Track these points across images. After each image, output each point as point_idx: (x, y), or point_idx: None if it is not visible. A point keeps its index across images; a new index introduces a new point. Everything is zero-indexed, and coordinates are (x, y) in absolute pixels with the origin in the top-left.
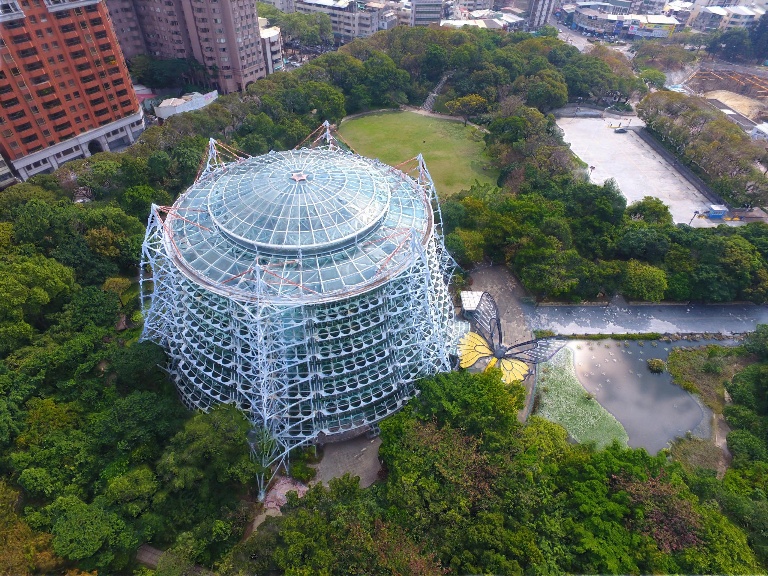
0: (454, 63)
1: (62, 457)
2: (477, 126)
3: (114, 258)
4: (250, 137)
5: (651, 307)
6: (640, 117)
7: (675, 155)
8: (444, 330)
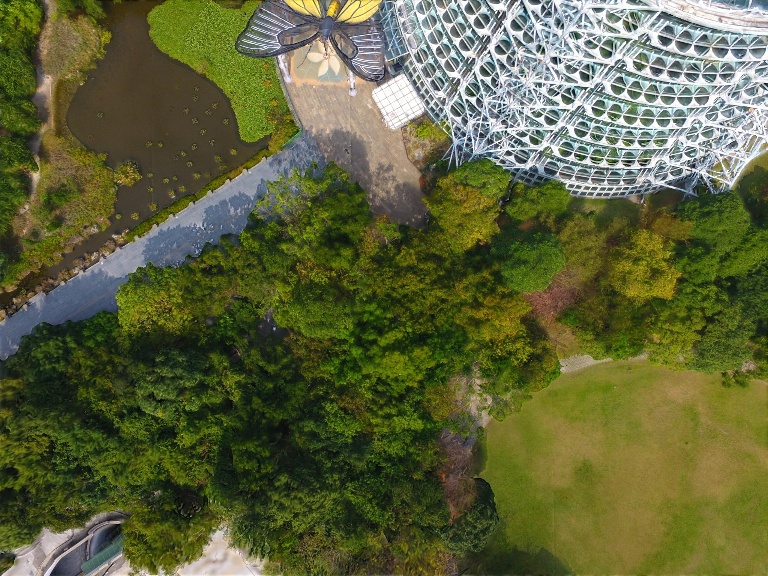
0: None
1: None
2: None
3: None
4: None
5: None
6: None
7: None
8: None
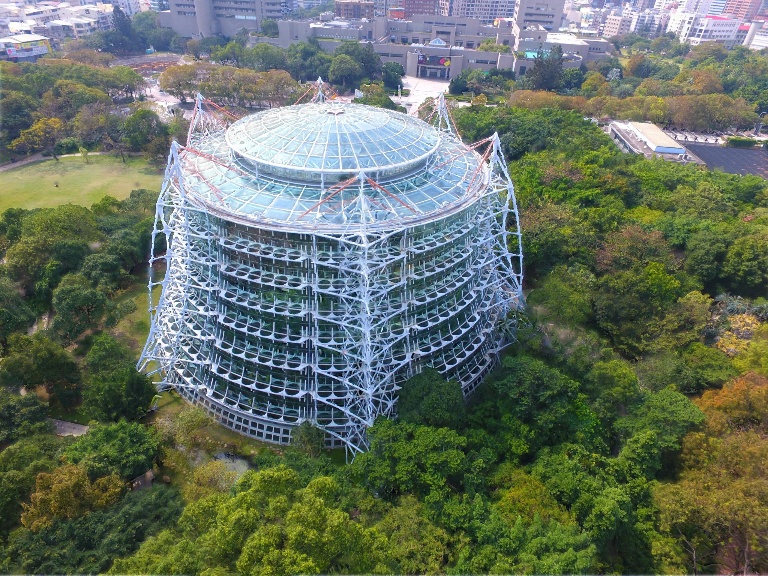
0: None
1: None
2: (83, 148)
3: (123, 490)
4: None
5: None
6: (174, 95)
7: None
8: None
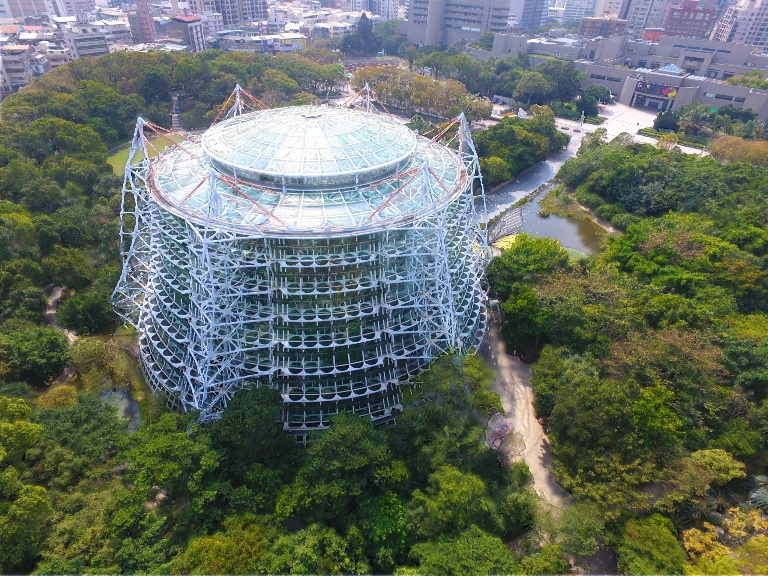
0: (178, 80)
1: (313, 570)
2: None
3: (4, 377)
4: (37, 182)
5: (502, 188)
6: None
7: (401, 111)
8: None
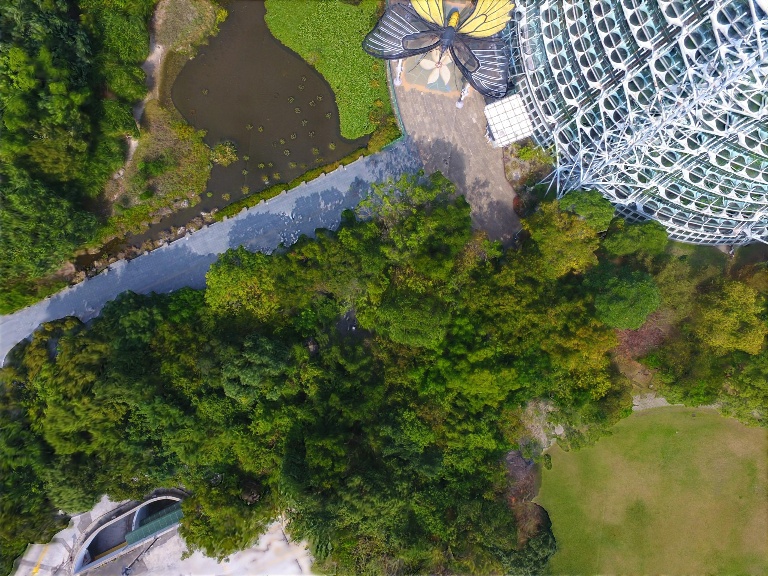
0: None
1: None
2: None
3: None
4: None
5: None
6: None
7: None
8: (542, 7)
